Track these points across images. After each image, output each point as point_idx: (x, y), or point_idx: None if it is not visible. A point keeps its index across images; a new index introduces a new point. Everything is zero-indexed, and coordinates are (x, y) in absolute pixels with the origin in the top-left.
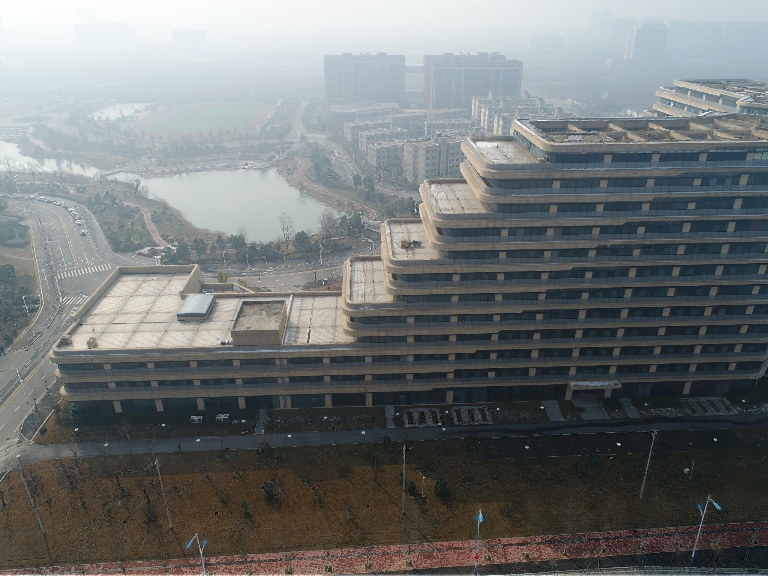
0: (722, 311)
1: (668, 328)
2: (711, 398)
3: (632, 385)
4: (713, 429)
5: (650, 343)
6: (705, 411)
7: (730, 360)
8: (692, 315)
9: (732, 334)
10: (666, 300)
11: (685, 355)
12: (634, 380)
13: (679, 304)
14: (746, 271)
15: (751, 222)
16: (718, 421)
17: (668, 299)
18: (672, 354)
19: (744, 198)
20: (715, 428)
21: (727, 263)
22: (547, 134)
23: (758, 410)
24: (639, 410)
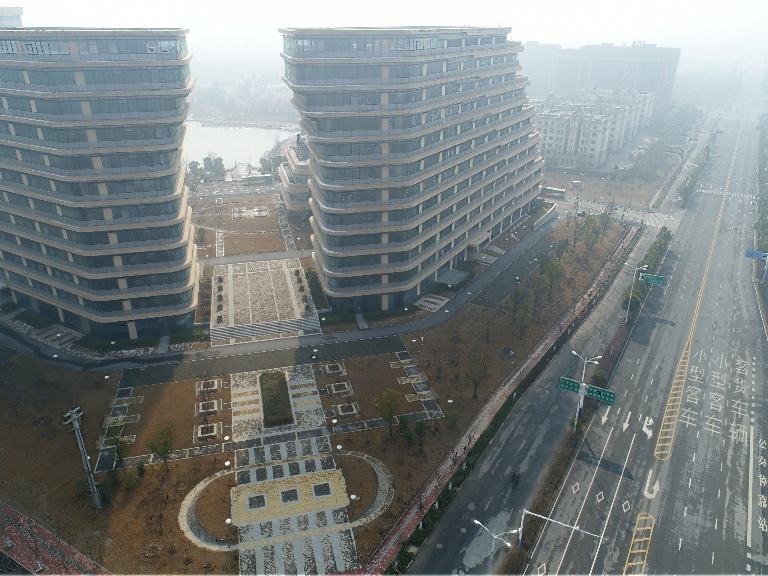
0: (46, 229)
1: (20, 238)
2: (76, 332)
3: (24, 296)
4: (11, 348)
5: (10, 250)
6: (44, 337)
7: (69, 290)
8: (29, 228)
9: (64, 260)
10: (6, 205)
11: (43, 274)
12: (18, 289)
13: (9, 210)
14: (43, 185)
15: (23, 126)
16: (31, 346)
17: (7, 204)
18: (34, 269)
19: (7, 97)
20: (14, 348)
21: (19, 171)
22: None
23: (78, 353)
24: (11, 318)
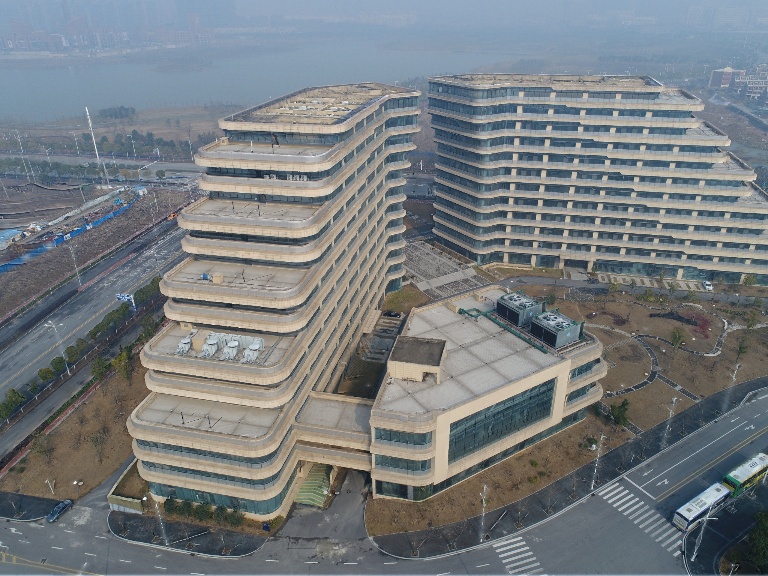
0: None
1: None
2: None
3: None
4: None
5: None
6: None
7: None
8: None
9: None
10: None
11: None
12: None
13: None
14: None
15: None
16: None
17: None
18: None
19: None
20: None
21: None
22: (642, 82)
23: None
24: None
